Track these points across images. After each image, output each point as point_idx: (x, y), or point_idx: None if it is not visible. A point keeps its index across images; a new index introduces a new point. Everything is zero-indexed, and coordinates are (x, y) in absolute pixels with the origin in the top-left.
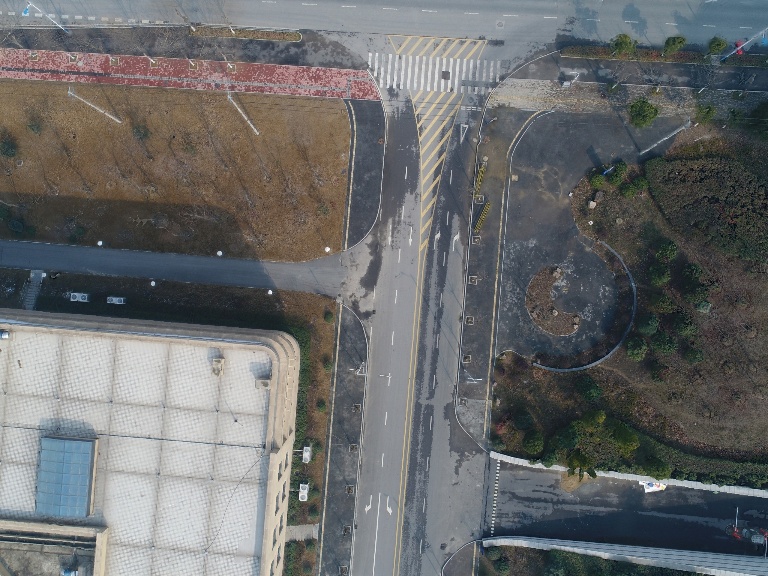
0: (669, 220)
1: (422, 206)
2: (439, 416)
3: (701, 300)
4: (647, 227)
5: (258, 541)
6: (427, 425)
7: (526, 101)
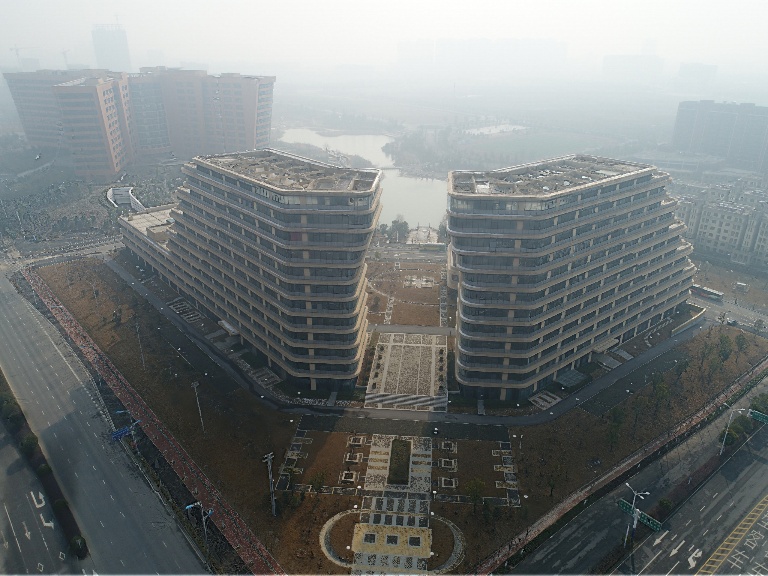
0: None
1: None
2: None
3: None
4: None
5: None
6: None
7: None
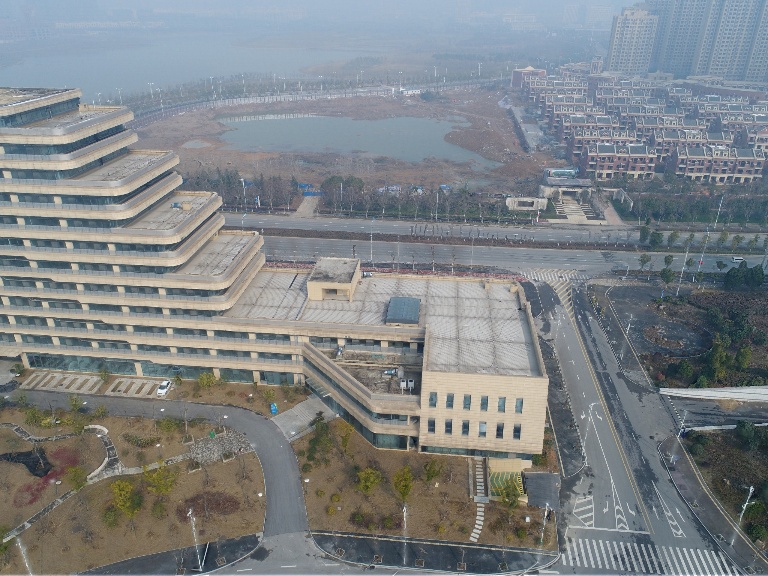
0: None
1: (566, 308)
2: (614, 377)
3: (747, 321)
4: None
5: (526, 338)
6: (608, 380)
7: (606, 283)
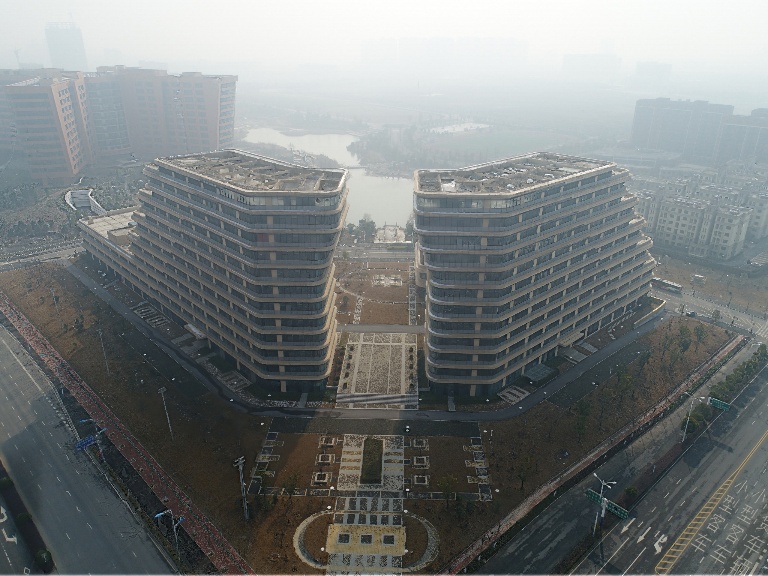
0: (1, 237)
1: None
2: None
3: None
4: (5, 238)
5: None
6: None
7: None
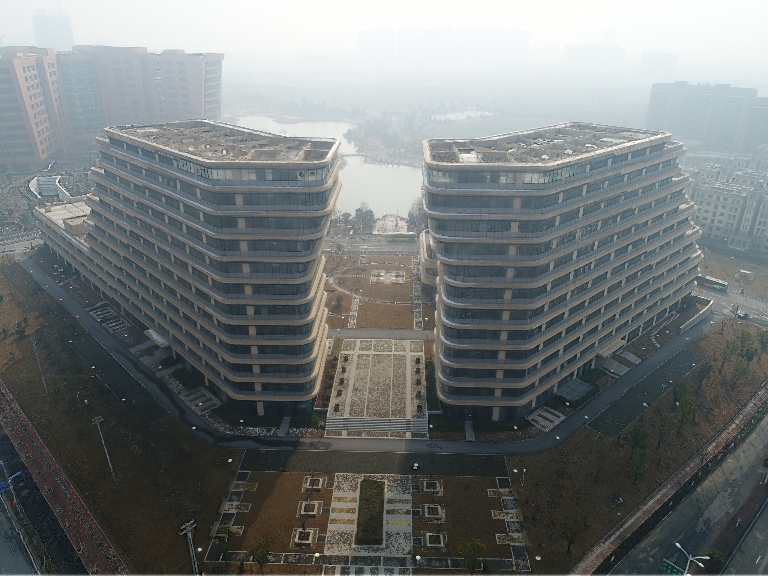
0: None
1: None
2: None
3: None
4: None
5: None
6: None
7: None
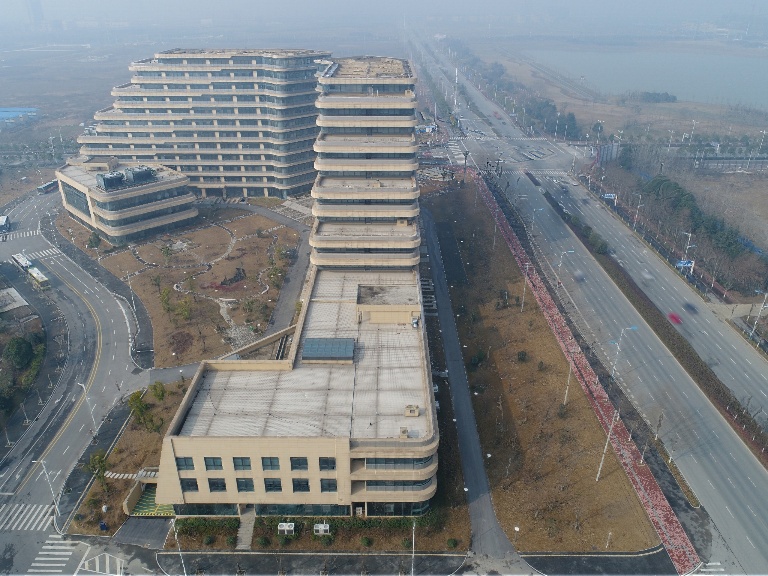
0: None
1: None
2: None
3: None
4: None
5: None
6: None
7: None
